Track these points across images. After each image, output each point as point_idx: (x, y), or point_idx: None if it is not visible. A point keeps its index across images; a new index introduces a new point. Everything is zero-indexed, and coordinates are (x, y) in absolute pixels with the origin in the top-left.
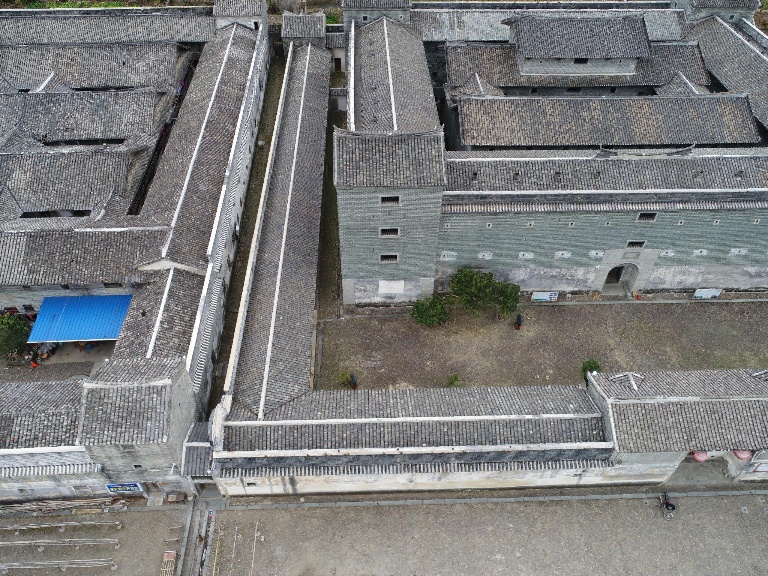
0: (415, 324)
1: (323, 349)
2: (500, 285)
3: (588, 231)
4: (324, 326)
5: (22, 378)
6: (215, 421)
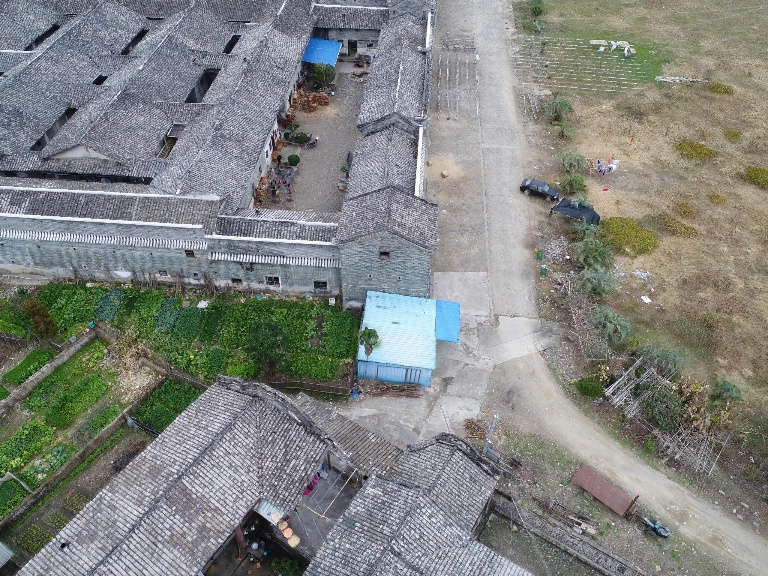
0: None
1: None
2: None
3: None
4: None
5: (344, 91)
6: None
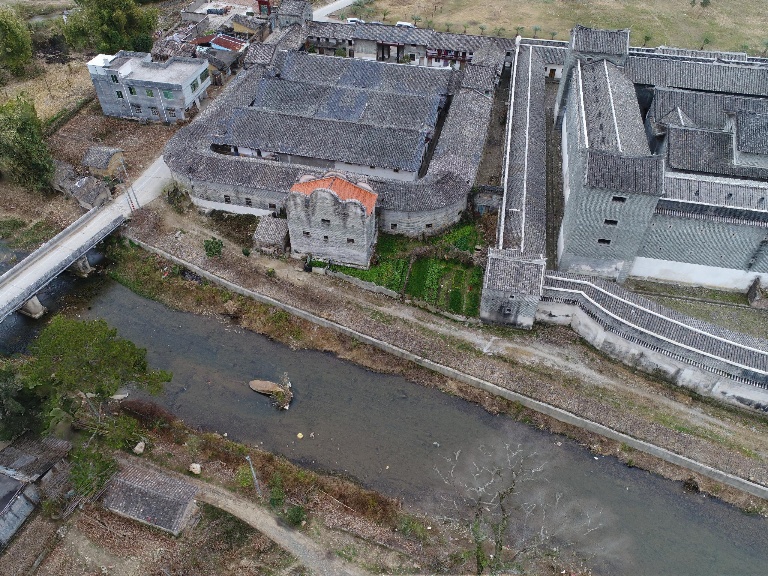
0: None
1: None
2: None
3: None
4: None
5: None
6: None
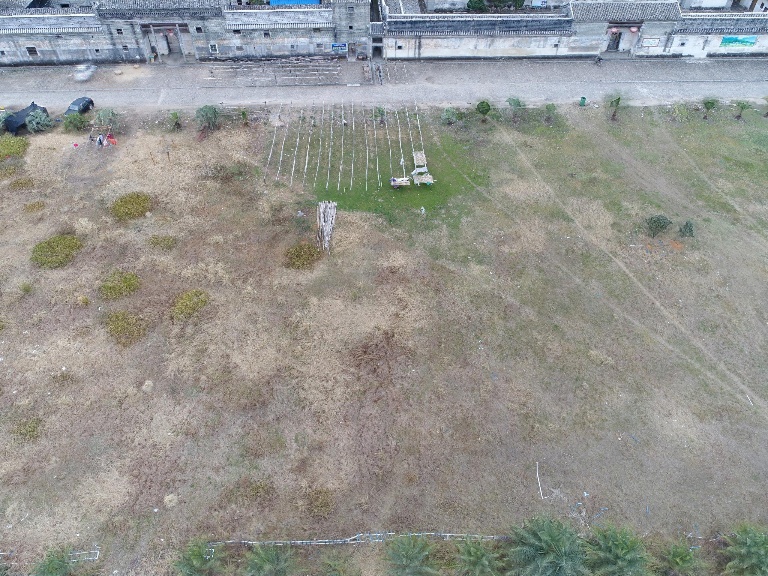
0: None
1: None
2: None
3: None
4: None
5: None
6: (386, 7)
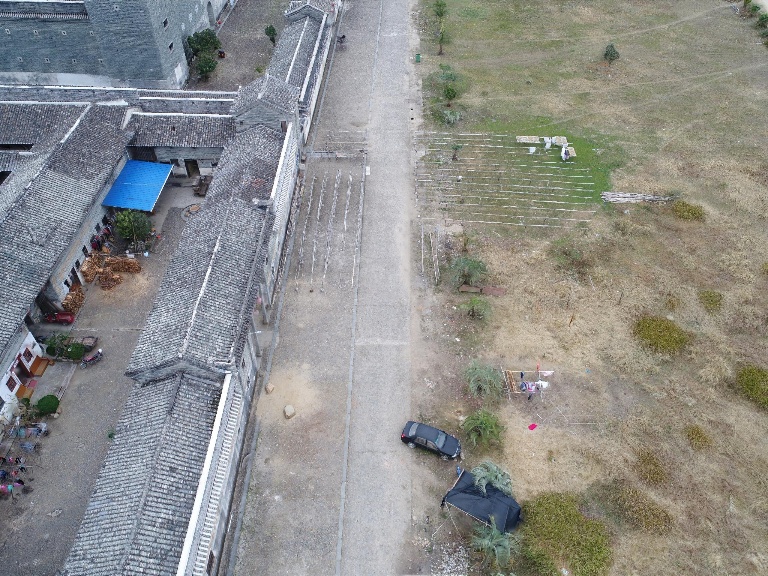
0: (202, 86)
1: None
2: (207, 31)
3: None
4: None
5: (170, 242)
6: None
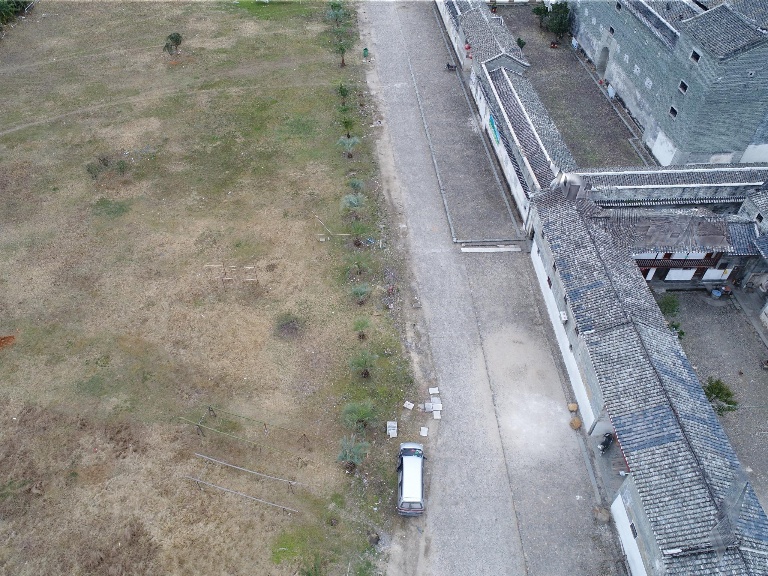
0: None
1: (513, 6)
2: None
3: (603, 6)
4: (528, 6)
5: None
6: None
